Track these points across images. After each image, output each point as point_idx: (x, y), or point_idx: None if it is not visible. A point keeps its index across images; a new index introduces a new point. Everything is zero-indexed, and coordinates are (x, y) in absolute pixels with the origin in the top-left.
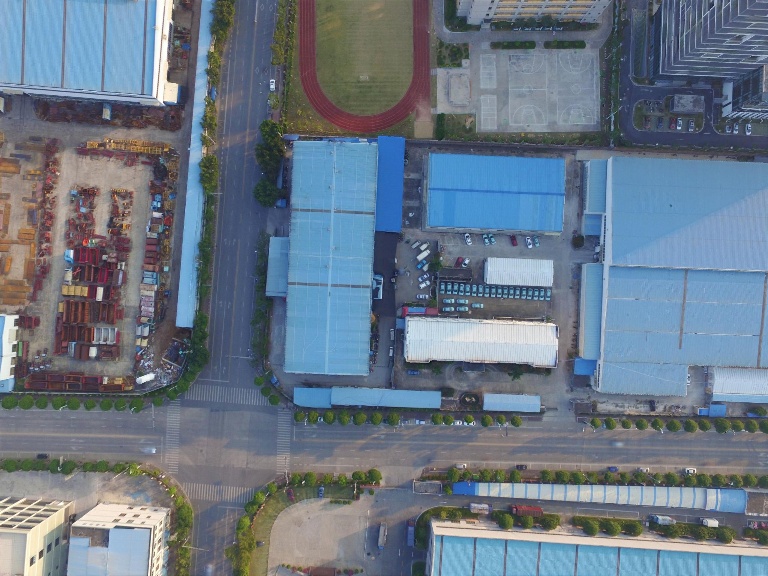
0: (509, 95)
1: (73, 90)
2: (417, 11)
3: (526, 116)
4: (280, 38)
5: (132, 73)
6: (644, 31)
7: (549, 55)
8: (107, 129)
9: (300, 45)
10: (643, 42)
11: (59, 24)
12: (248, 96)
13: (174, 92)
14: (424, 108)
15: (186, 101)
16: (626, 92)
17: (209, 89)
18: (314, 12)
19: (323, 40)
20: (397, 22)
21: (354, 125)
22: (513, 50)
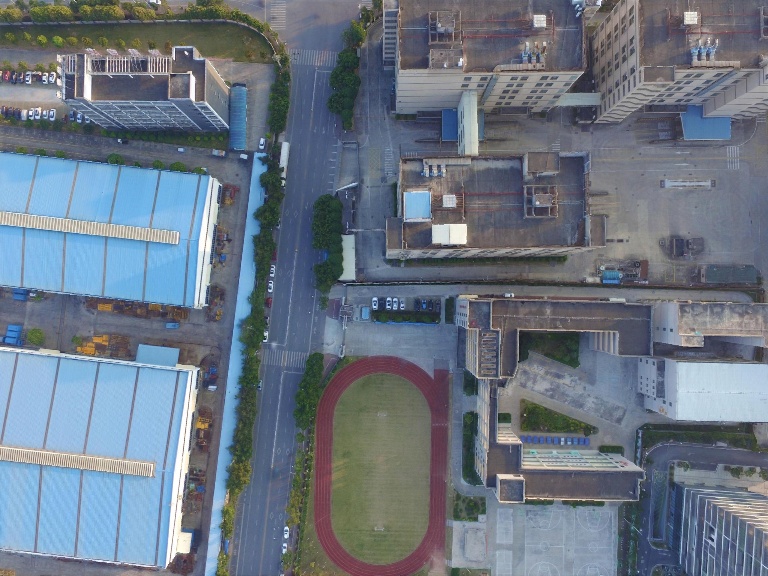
0: (525, 551)
1: (86, 559)
2: (435, 459)
3: (542, 573)
4: (296, 502)
5: (146, 545)
6: (664, 492)
7: (567, 511)
8: (118, 570)
9: (316, 491)
10: (663, 501)
11: (75, 497)
12: (261, 542)
13: (187, 542)
14: (439, 559)
15: (199, 544)
16: (644, 555)
17: (222, 537)
18: (331, 458)
19: (339, 486)
20: (414, 470)
21: (367, 574)
22: (531, 505)
